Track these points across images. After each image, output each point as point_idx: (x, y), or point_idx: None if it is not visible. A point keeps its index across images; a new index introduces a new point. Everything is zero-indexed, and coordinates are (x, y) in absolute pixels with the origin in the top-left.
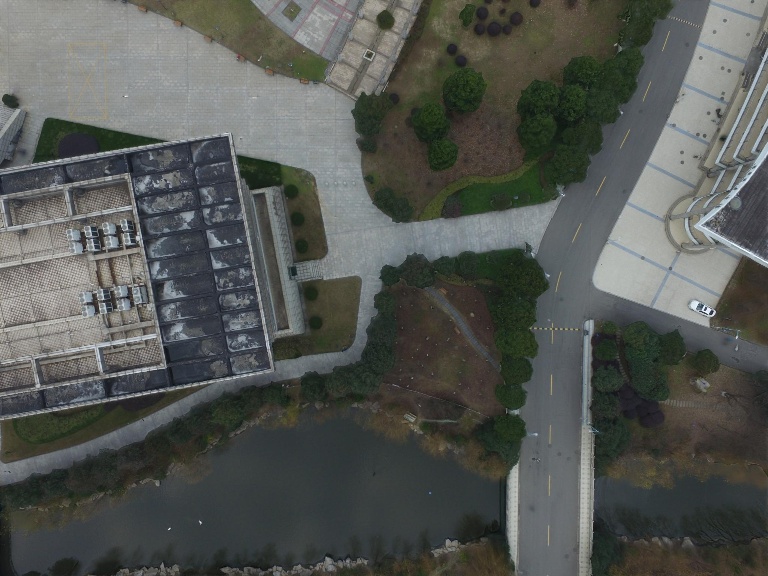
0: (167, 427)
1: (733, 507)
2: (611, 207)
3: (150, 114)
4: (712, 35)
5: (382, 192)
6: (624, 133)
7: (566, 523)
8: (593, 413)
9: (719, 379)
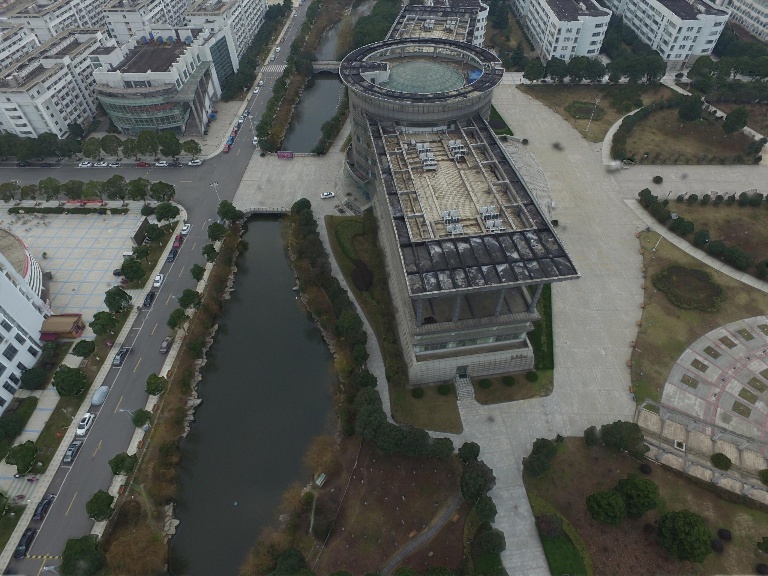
0: None
1: None
2: None
3: (568, 289)
4: None
5: (551, 442)
6: None
7: None
8: None
9: None
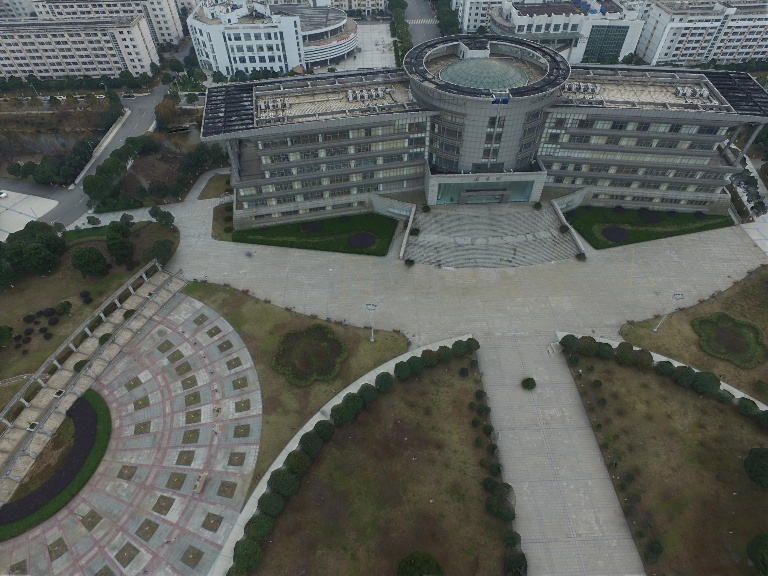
0: None
1: (37, 150)
2: None
3: (315, 262)
4: None
5: (164, 214)
6: None
7: (125, 130)
8: None
9: None
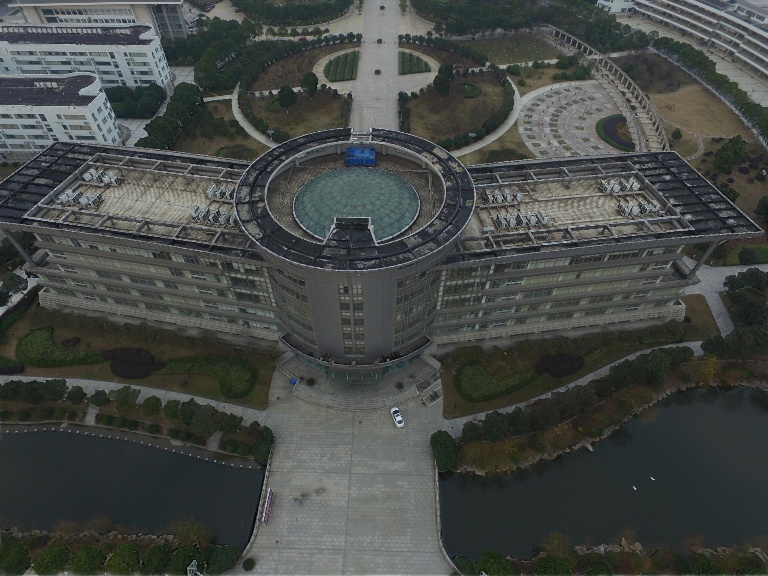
0: None
1: None
2: None
3: None
4: None
5: None
6: None
7: None
8: None
9: None
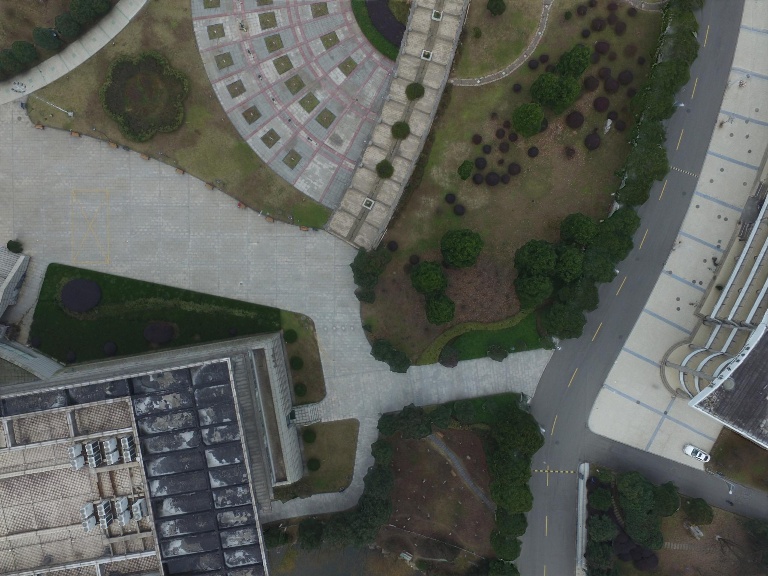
0: None
1: None
2: (607, 352)
3: (152, 259)
4: (709, 184)
5: (380, 348)
6: (620, 280)
7: None
8: None
9: (713, 522)
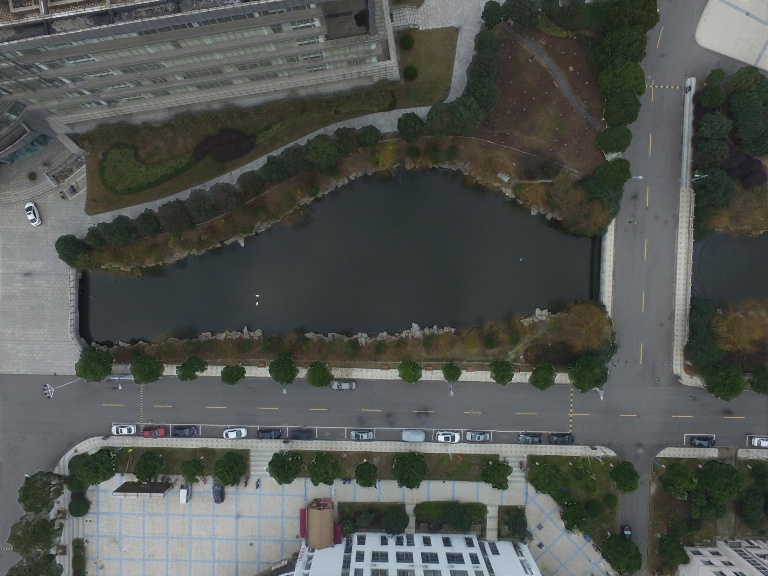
0: (259, 172)
1: None
2: None
3: None
4: None
5: None
6: None
7: (661, 290)
8: (693, 172)
9: None
